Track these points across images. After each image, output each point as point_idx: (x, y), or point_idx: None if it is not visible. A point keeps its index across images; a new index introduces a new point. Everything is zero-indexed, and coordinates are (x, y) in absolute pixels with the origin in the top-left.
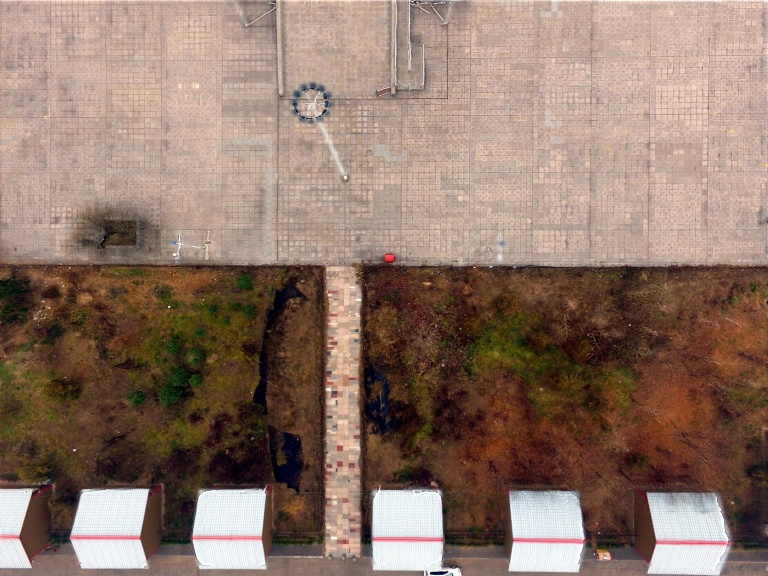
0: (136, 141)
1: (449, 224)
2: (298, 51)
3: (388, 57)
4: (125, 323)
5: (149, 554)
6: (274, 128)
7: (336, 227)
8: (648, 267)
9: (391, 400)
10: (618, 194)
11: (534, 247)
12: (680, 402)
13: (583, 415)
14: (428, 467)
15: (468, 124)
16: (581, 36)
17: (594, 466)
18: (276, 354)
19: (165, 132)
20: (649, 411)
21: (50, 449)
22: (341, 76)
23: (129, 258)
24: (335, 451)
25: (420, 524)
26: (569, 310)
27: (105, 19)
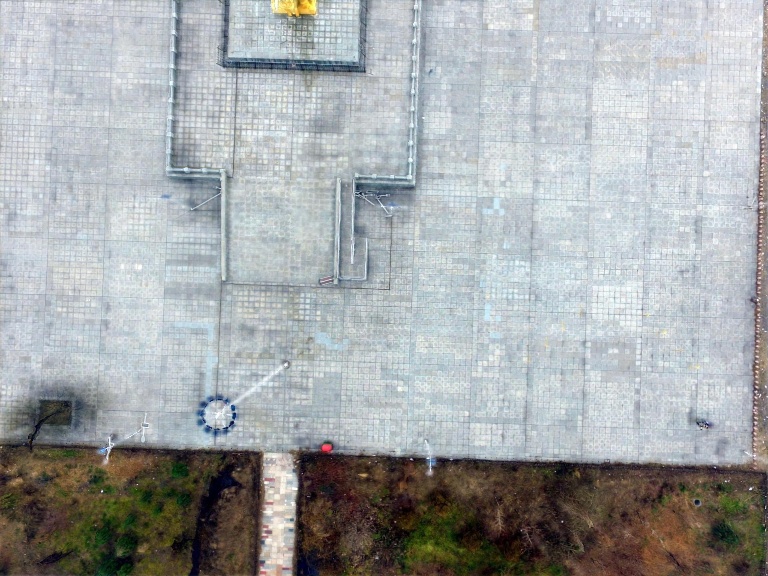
0: (75, 320)
1: (388, 414)
2: (242, 238)
3: (332, 248)
4: (56, 507)
5: None
6: (216, 312)
7: (275, 413)
8: (581, 463)
9: None
10: (554, 390)
11: (471, 440)
12: None
13: None
14: None
15: (409, 316)
16: (522, 234)
17: None
18: (209, 545)
19: (105, 312)
20: None
21: None
22: (285, 264)
23: (63, 438)
24: None
25: None
26: (503, 506)
27: (49, 196)
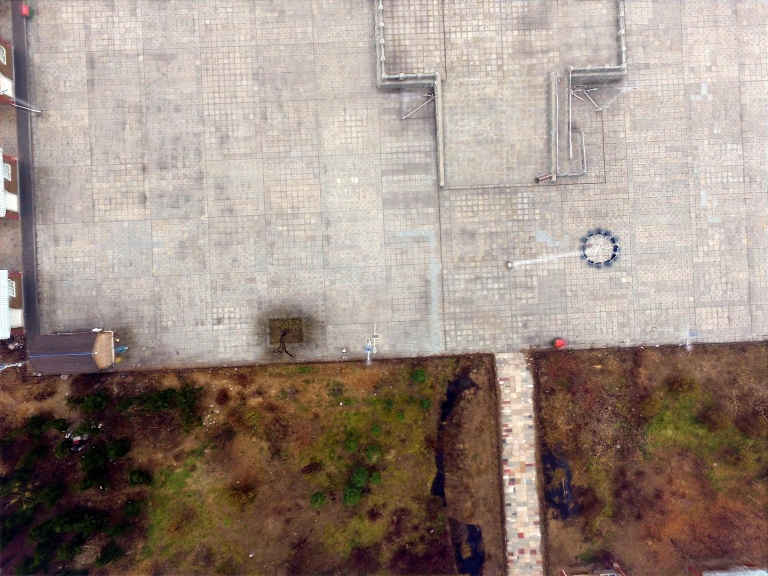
0: (297, 237)
1: (614, 306)
2: (458, 142)
3: (547, 145)
4: (297, 423)
5: None
6: (436, 219)
7: (503, 314)
8: None
9: (573, 486)
10: None
11: (698, 324)
12: None
13: None
14: (608, 548)
15: (627, 207)
16: (731, 117)
17: None
18: (454, 446)
19: (326, 227)
20: None
21: (225, 556)
22: (501, 165)
23: (295, 356)
24: (516, 539)
25: None
26: (737, 385)
27: (259, 116)
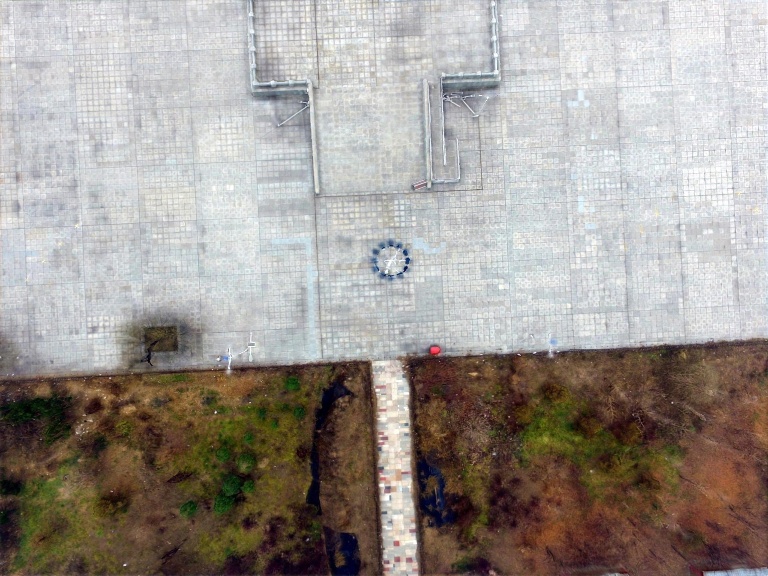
0: (172, 246)
1: (491, 313)
2: (332, 149)
3: (422, 152)
4: (171, 432)
5: None
6: (312, 226)
7: (379, 322)
8: (686, 345)
9: (446, 494)
10: (653, 275)
11: (575, 331)
12: (725, 474)
13: None
14: (485, 556)
15: (504, 214)
16: (608, 123)
17: (647, 543)
18: (328, 454)
19: (201, 235)
20: None
21: (99, 566)
22: (376, 172)
23: (171, 364)
24: (392, 547)
25: None
26: (613, 392)
27: (134, 124)
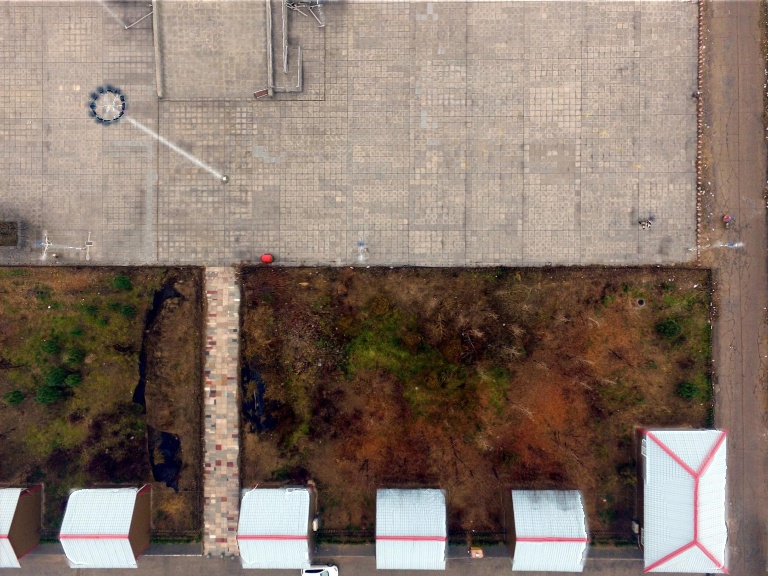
0: (18, 143)
1: (327, 225)
2: (176, 53)
3: (265, 59)
4: (5, 323)
5: (22, 553)
6: (154, 130)
7: (216, 228)
8: (522, 267)
9: (266, 399)
10: (493, 195)
11: (411, 247)
12: (553, 401)
13: (458, 414)
14: (306, 466)
15: (345, 126)
16: (456, 39)
17: (469, 464)
18: (153, 354)
19: (46, 134)
20: (523, 410)
21: None
22: (220, 78)
23: (11, 259)
24: (214, 450)
25: (288, 522)
26: (444, 310)
27: None
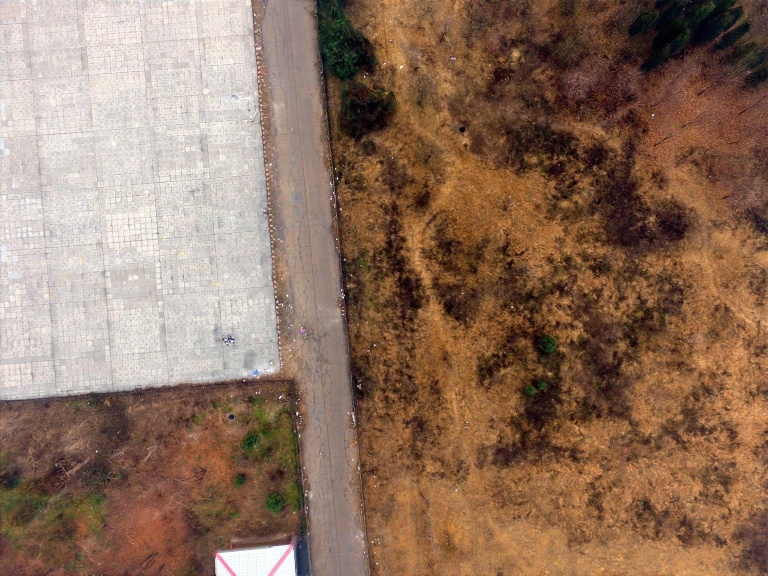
0: None
1: None
2: None
3: None
4: None
5: None
6: None
7: None
8: (112, 392)
9: None
10: (78, 323)
11: (0, 382)
12: (152, 522)
13: (57, 545)
14: None
15: None
16: (29, 172)
17: None
18: None
19: None
20: (122, 534)
21: None
22: None
23: None
24: None
25: None
26: (33, 443)
27: None
